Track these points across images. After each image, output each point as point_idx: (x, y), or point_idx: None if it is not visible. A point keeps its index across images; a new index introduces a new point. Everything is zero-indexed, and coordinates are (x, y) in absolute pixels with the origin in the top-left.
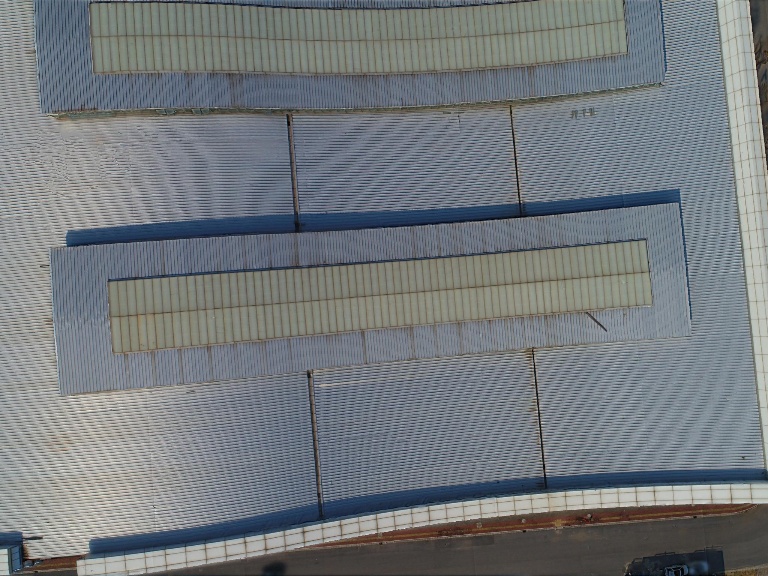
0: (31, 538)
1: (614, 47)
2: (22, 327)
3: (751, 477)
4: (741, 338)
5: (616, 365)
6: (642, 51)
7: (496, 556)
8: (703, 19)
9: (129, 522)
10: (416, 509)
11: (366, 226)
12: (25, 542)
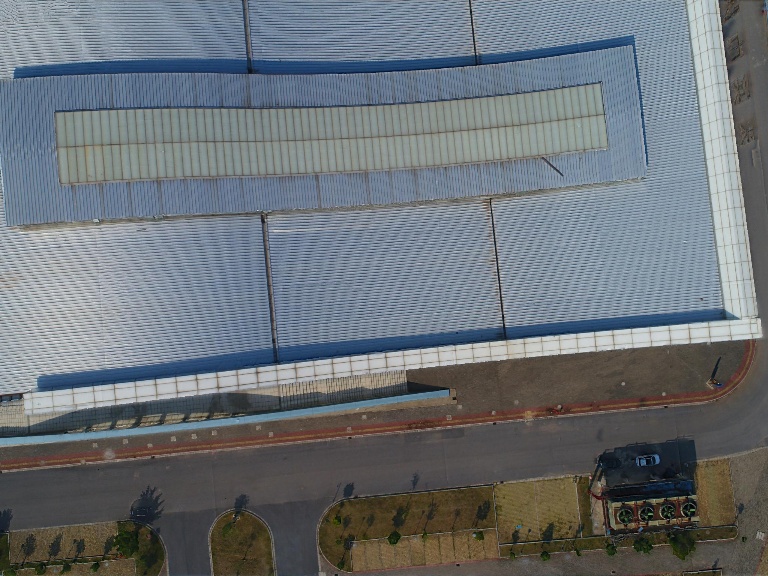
0: None
1: None
2: None
3: (710, 318)
4: (697, 179)
5: (574, 213)
6: None
7: (466, 449)
8: None
9: (78, 359)
10: (373, 355)
11: None
12: None
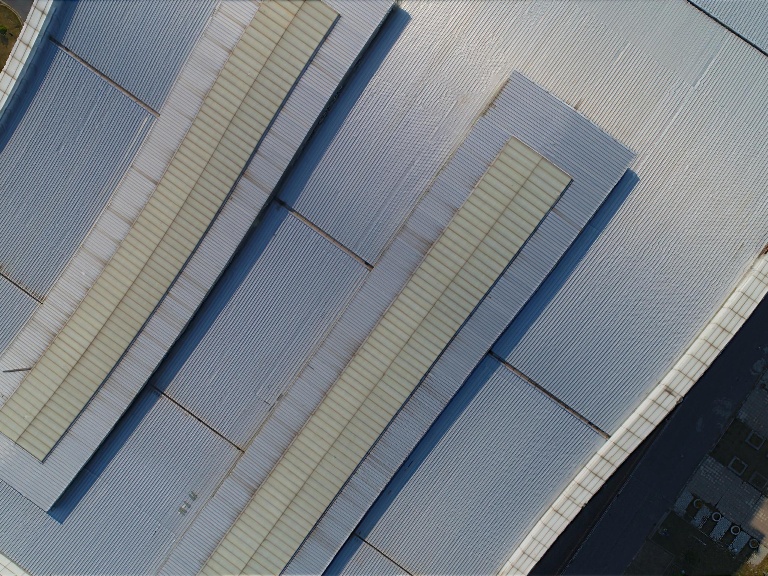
0: None
1: (210, 571)
2: None
3: None
4: None
5: None
6: None
7: None
8: None
9: None
10: None
11: (242, 258)
12: None
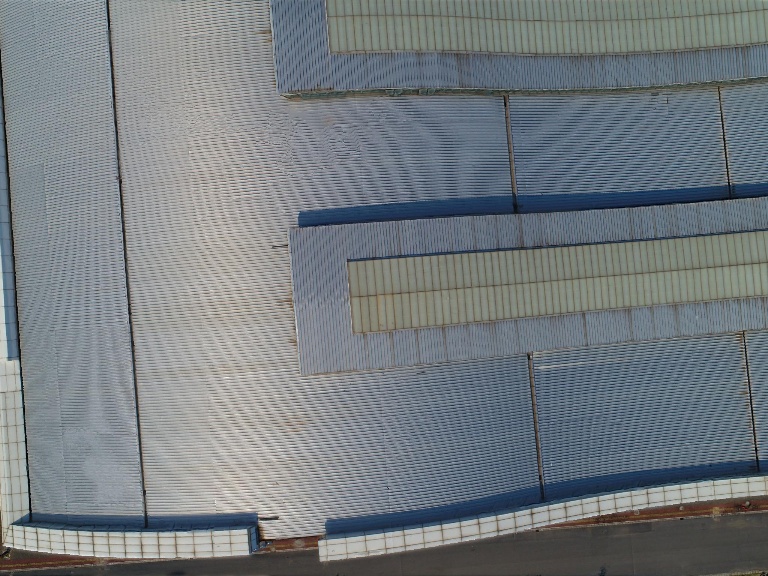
0: (267, 518)
1: None
2: (255, 308)
3: None
4: None
5: None
6: None
7: (654, 543)
8: None
9: (364, 503)
10: (635, 492)
11: (579, 208)
12: (261, 522)
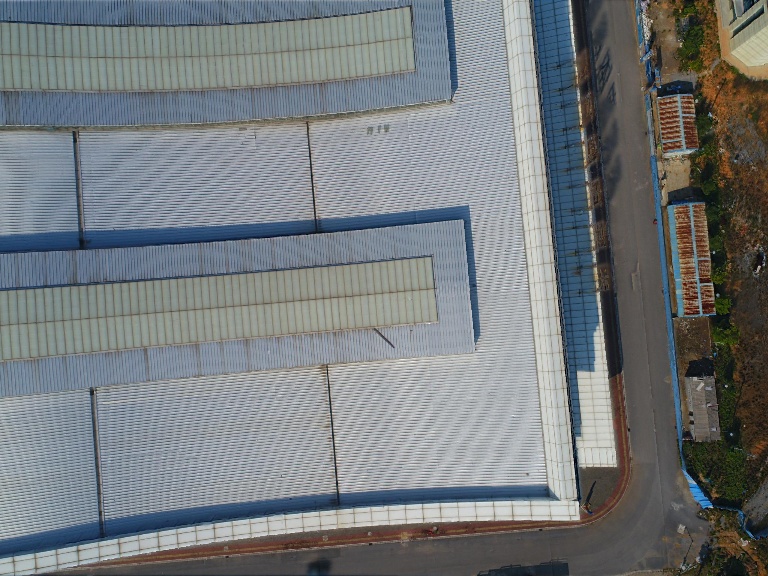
0: None
1: (402, 64)
2: None
3: (534, 494)
4: (526, 355)
5: (408, 381)
6: (429, 68)
7: (342, 569)
8: (492, 36)
9: None
10: (201, 526)
11: (156, 243)
12: None
